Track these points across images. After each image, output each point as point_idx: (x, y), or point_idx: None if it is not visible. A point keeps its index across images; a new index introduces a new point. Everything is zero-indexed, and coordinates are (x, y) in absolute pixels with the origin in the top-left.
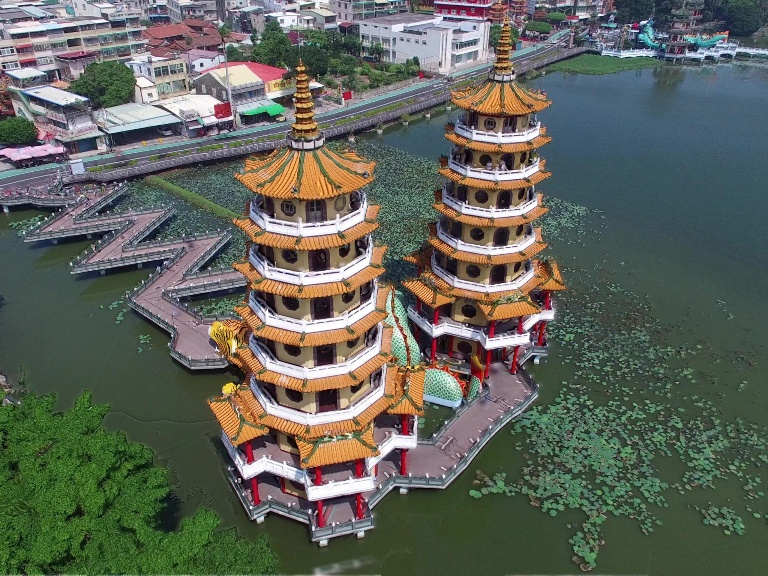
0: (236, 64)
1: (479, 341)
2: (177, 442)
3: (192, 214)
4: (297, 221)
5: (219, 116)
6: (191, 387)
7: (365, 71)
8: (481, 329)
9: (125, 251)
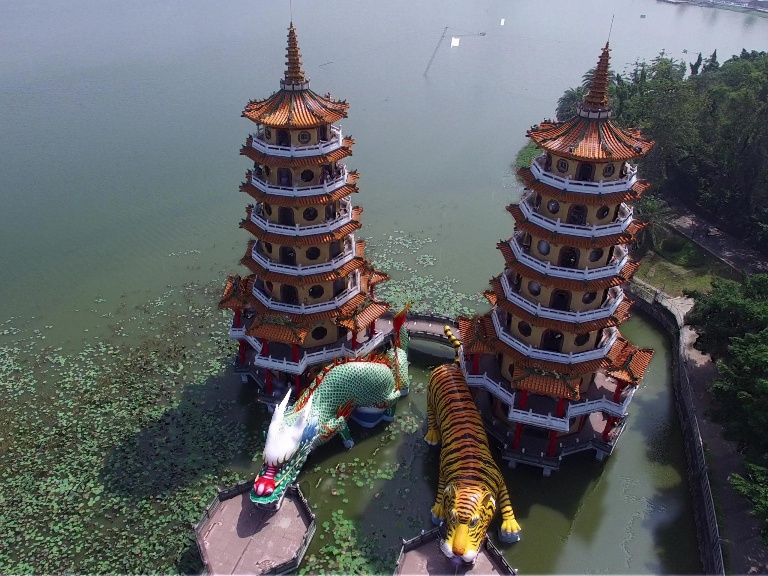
0: None
1: None
2: None
3: None
4: None
5: None
6: None
7: None
8: None
9: None
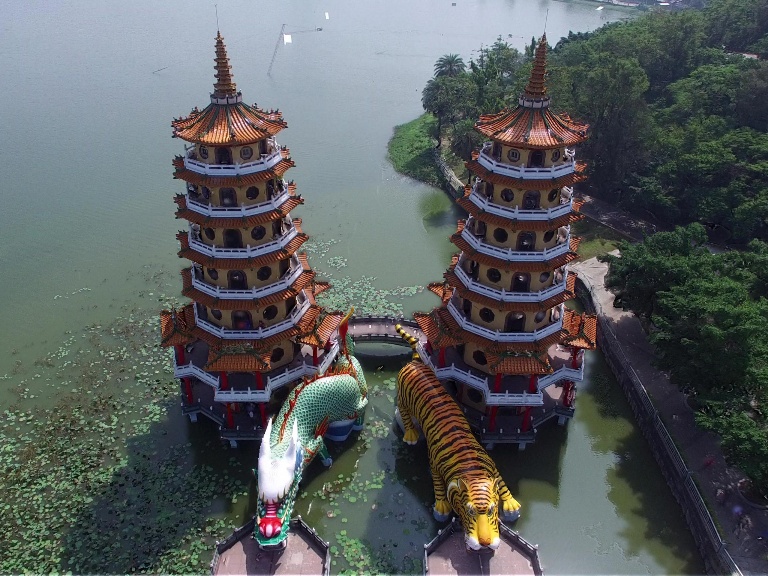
0: None
1: None
2: (576, 568)
3: None
4: None
5: None
6: None
7: None
8: None
9: None
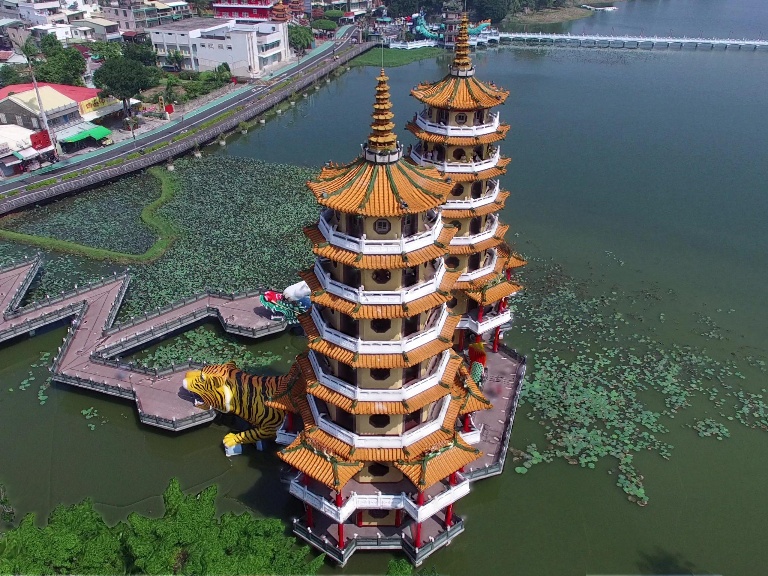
0: (20, 86)
1: (469, 328)
2: None
3: (60, 262)
4: (393, 238)
5: (37, 147)
6: (173, 451)
7: (173, 82)
8: (469, 316)
9: (8, 319)
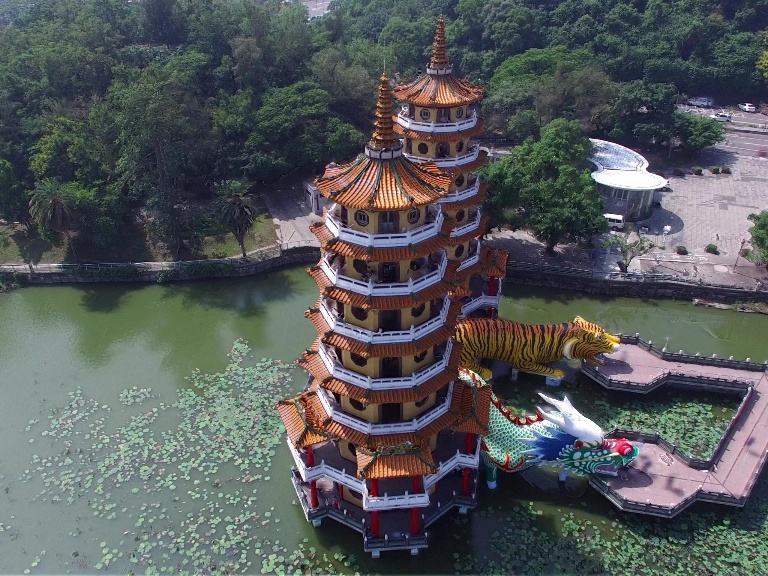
0: None
1: None
2: None
3: None
4: None
5: None
6: None
7: None
8: None
9: None
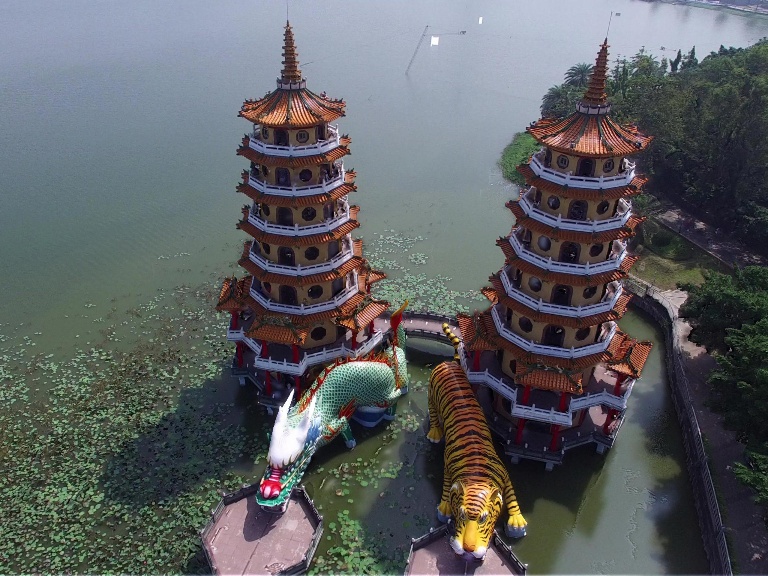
0: None
1: None
2: None
3: None
4: None
5: None
6: None
7: None
8: None
9: None
